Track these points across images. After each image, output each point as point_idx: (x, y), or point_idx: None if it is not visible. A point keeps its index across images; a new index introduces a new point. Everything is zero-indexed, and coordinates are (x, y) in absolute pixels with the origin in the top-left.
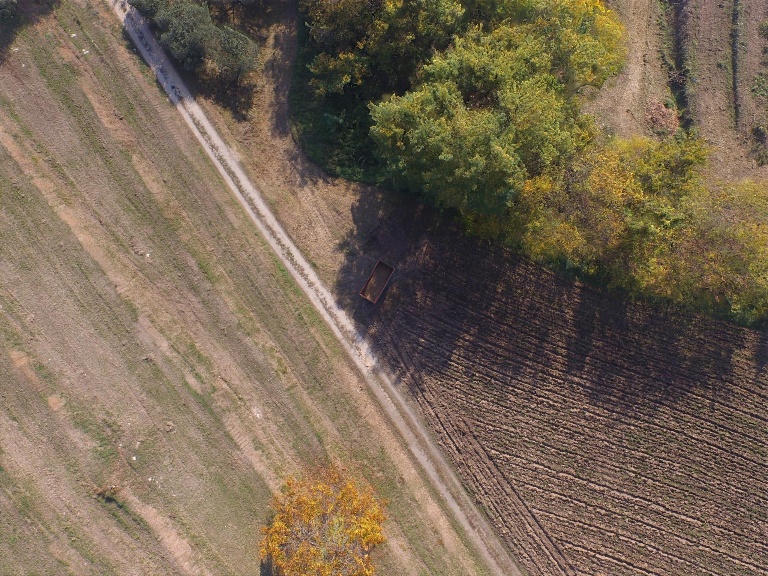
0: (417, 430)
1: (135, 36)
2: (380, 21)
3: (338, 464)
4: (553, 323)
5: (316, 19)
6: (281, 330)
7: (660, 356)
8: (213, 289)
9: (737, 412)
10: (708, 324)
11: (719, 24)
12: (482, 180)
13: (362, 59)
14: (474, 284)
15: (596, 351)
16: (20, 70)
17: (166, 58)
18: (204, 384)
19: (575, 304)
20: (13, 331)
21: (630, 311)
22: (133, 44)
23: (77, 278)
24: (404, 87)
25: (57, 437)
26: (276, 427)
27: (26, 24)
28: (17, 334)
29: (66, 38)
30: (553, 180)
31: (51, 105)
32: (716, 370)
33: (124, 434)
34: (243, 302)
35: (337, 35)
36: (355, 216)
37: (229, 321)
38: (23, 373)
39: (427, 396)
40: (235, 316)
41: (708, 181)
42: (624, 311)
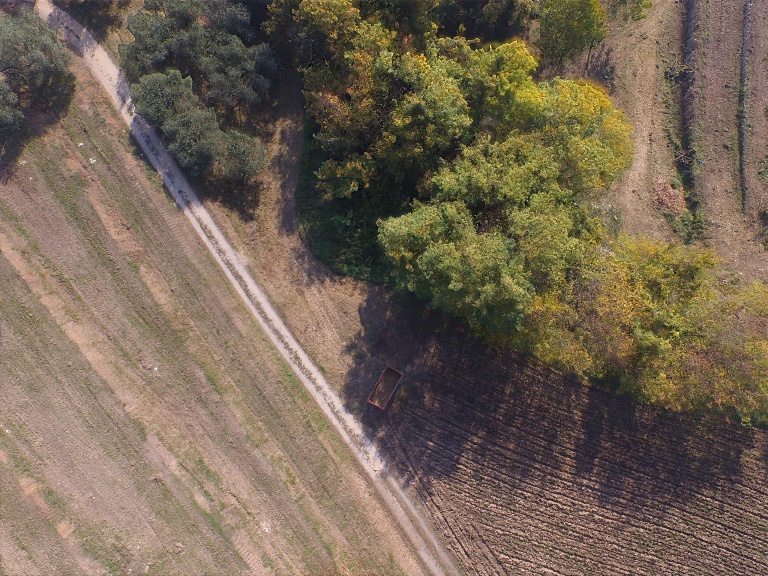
0: (426, 534)
1: (142, 140)
2: (388, 132)
3: (347, 575)
4: (561, 424)
5: (323, 127)
6: (289, 439)
7: (669, 457)
8: (221, 401)
9: (747, 514)
10: (717, 423)
11: (725, 105)
12: (491, 304)
13: (369, 163)
14: (482, 386)
15: (605, 453)
16: (27, 184)
17: (173, 162)
18: (213, 502)
19: (583, 404)
20: (22, 456)
21: (639, 411)
22: (140, 148)
23: (85, 398)
24: (411, 183)
25: (66, 565)
26: (285, 540)
27: (33, 136)
28: (26, 459)
29: (73, 148)
30: (562, 293)
31: (58, 218)
32: (725, 471)
33: (133, 558)
34: (251, 411)
35: (344, 142)
36: (363, 317)
37: (237, 433)
38: (32, 501)
39: (436, 500)
40: (243, 428)
41: (715, 265)
42: (633, 411)
